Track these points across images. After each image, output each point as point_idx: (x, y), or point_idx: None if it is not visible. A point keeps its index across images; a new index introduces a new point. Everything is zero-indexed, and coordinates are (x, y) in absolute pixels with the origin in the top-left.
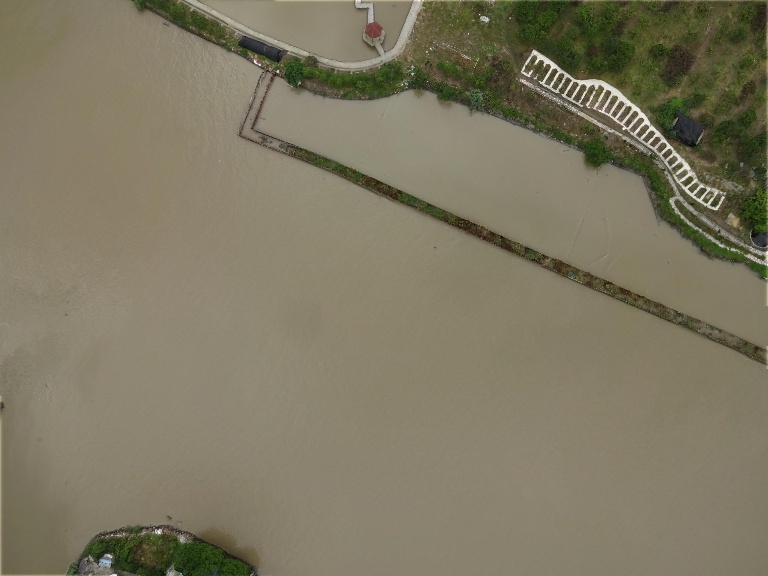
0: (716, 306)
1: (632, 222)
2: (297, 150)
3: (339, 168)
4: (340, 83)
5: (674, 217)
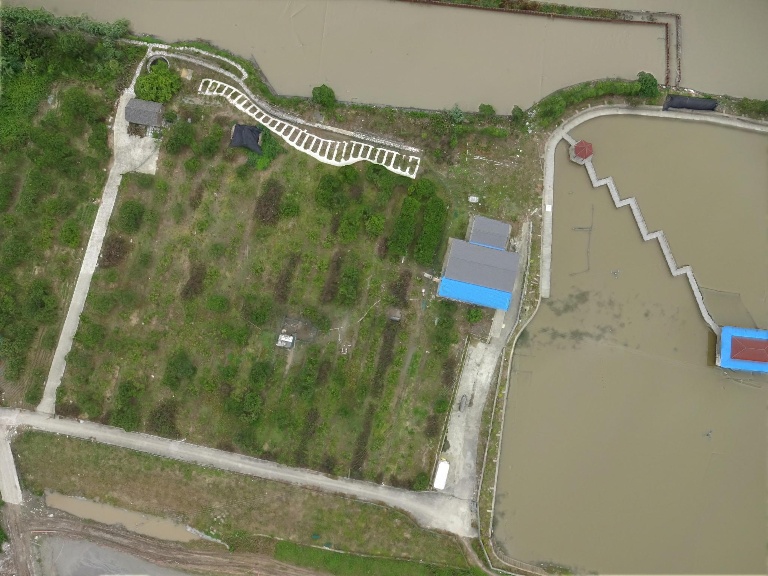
0: (187, 0)
1: (277, 51)
2: (614, 17)
3: (567, 11)
4: (598, 84)
5: (241, 59)
